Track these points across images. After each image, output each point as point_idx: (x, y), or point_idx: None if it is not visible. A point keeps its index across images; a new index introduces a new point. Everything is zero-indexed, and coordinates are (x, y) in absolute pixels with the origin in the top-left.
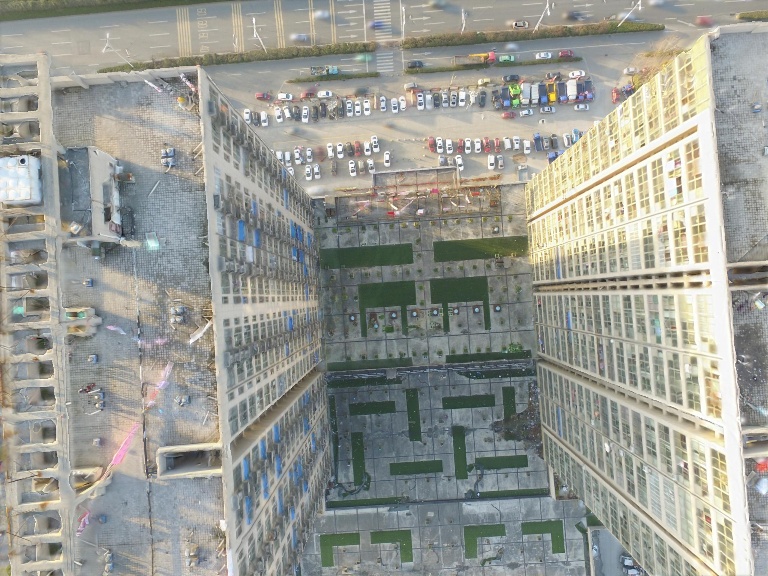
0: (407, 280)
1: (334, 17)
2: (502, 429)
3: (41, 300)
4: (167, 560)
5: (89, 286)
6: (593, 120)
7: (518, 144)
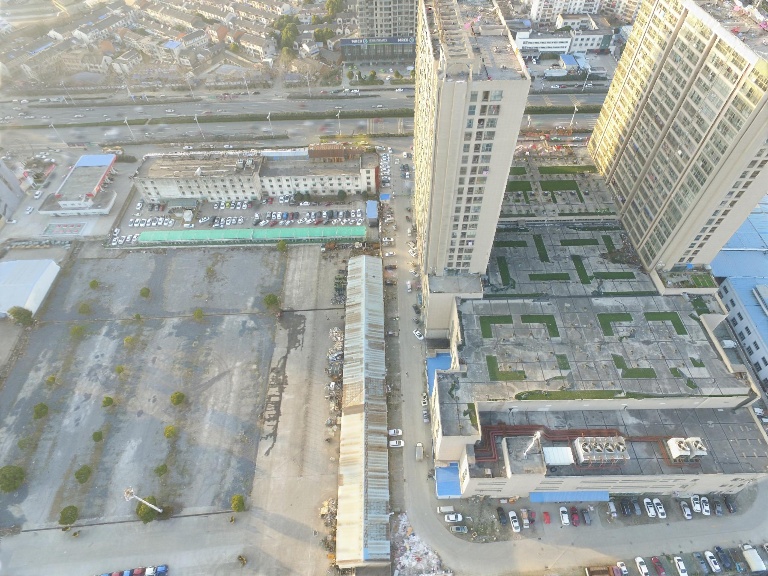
0: (524, 181)
1: None
2: (608, 257)
3: None
4: None
5: None
6: None
7: None
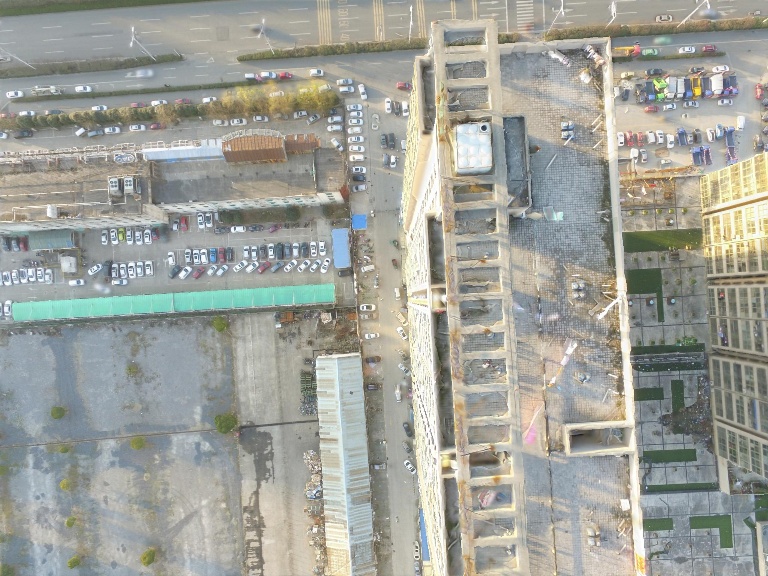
0: None
1: (476, 7)
2: (670, 422)
3: (438, 273)
4: (567, 539)
5: None
6: (736, 115)
7: (662, 138)
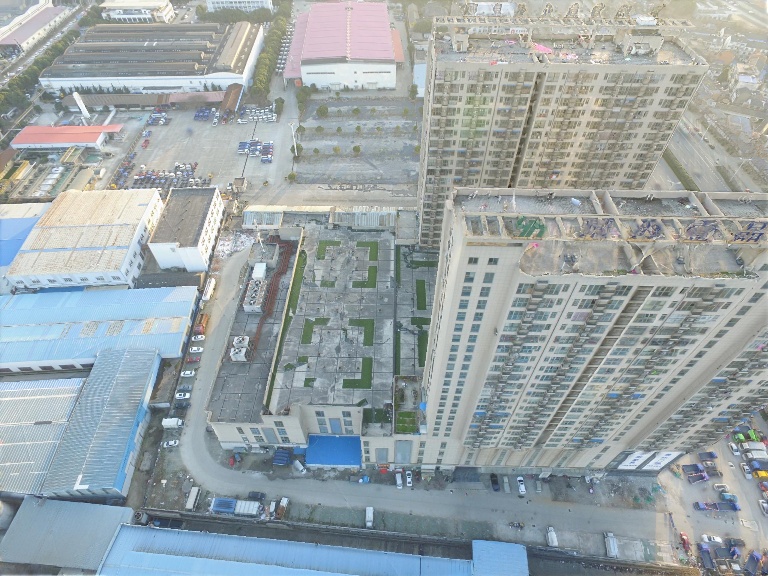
0: None
1: None
2: None
3: None
4: None
5: None
6: (756, 521)
7: None
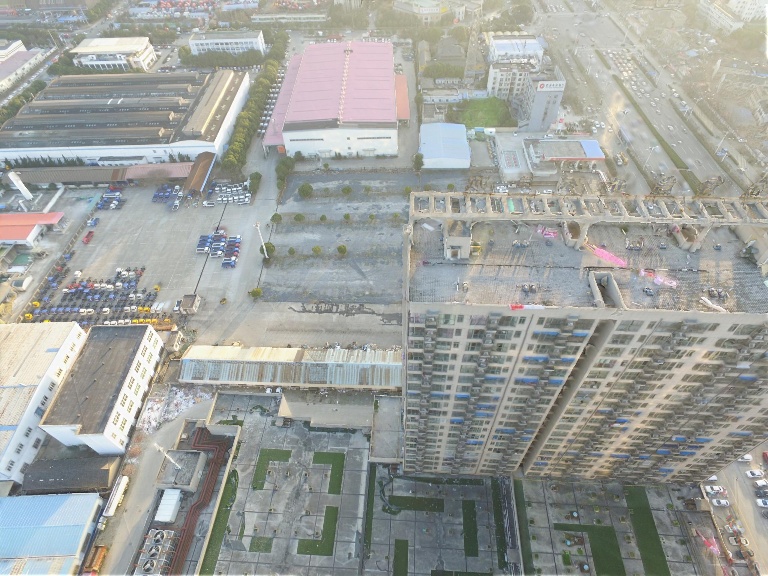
0: None
1: None
2: None
3: (694, 224)
4: (524, 274)
5: (714, 248)
6: None
7: None
